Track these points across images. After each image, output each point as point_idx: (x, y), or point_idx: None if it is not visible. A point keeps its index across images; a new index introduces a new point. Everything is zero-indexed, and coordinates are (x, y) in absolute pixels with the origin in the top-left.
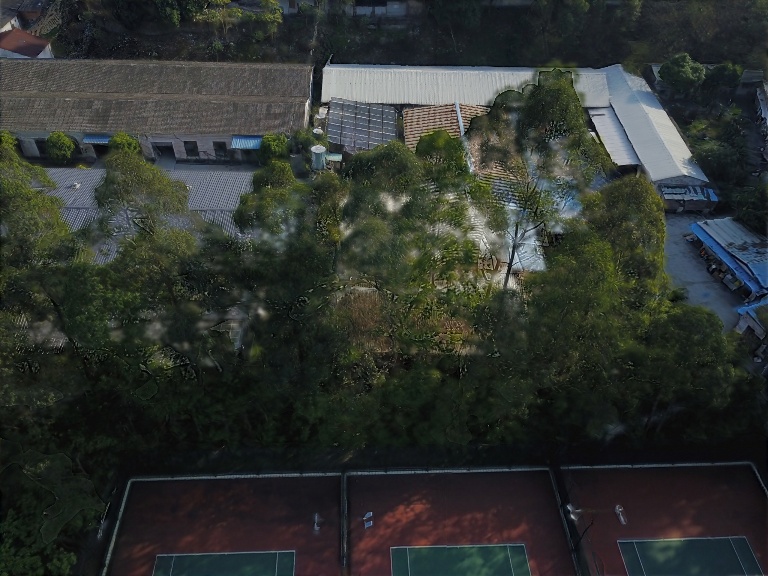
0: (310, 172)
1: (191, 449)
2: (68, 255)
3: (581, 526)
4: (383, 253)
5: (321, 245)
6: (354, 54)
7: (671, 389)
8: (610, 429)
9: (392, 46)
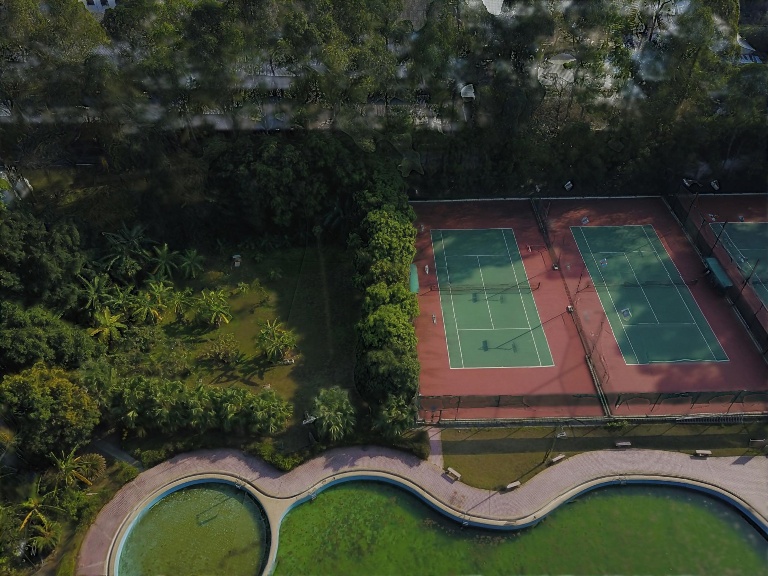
0: None
1: (434, 186)
2: (406, 31)
3: (688, 205)
4: (595, 4)
5: (551, 15)
6: None
7: (743, 118)
8: (701, 165)
9: None
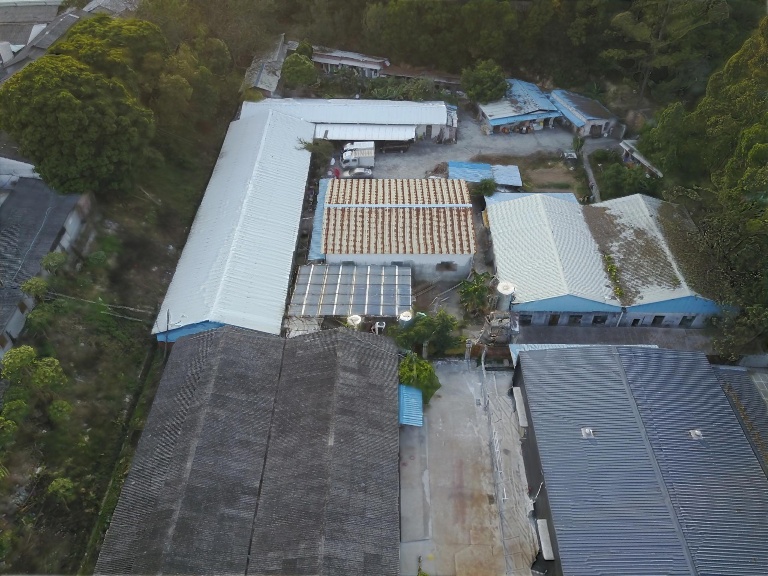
0: (453, 344)
1: None
2: None
3: None
4: None
5: None
6: (128, 302)
7: None
8: None
9: (129, 257)
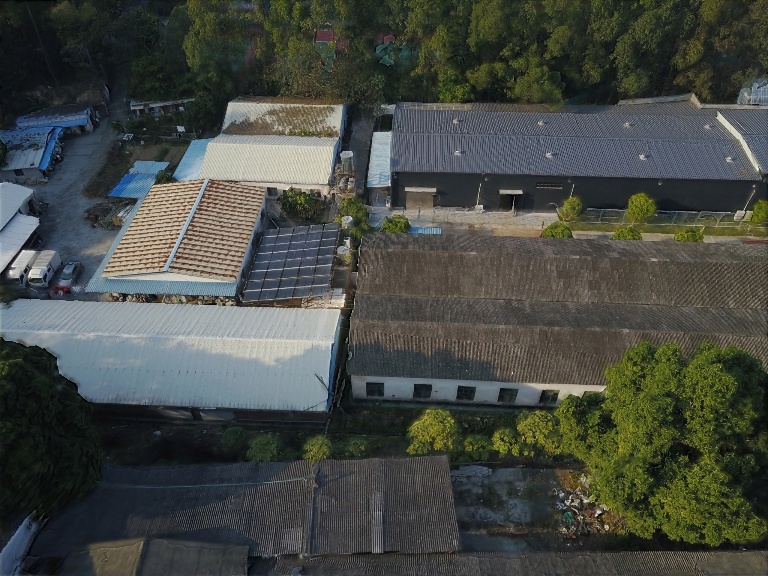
0: None
1: None
2: None
3: None
4: None
5: None
6: None
7: None
8: None
9: (189, 453)
